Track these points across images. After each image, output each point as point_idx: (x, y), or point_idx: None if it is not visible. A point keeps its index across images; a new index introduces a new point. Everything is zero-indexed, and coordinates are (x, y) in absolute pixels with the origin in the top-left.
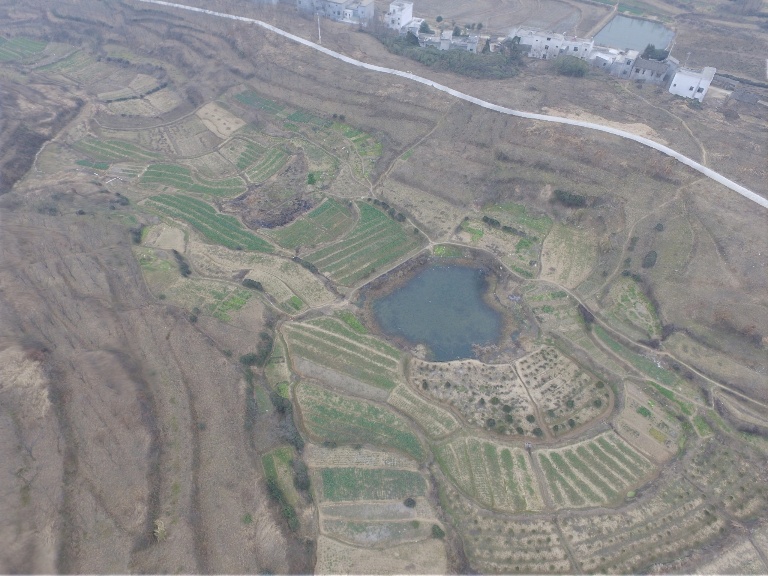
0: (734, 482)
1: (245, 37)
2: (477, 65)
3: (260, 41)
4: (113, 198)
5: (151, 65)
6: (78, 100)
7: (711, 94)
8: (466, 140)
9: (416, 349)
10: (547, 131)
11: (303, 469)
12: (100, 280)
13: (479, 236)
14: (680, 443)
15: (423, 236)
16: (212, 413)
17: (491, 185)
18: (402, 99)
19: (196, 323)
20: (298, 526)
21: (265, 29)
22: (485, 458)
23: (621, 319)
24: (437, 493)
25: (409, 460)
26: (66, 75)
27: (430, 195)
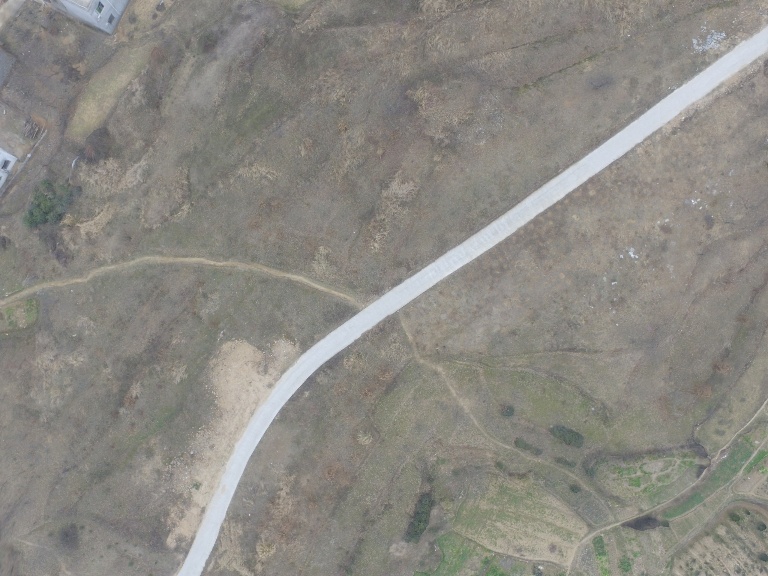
0: None
1: None
2: None
3: None
4: None
5: None
6: None
7: None
8: None
9: None
10: None
11: None
12: None
13: None
14: None
15: None
16: None
17: None
18: None
19: None
20: None
21: None
22: None
23: None
24: None
25: None
26: None
27: None
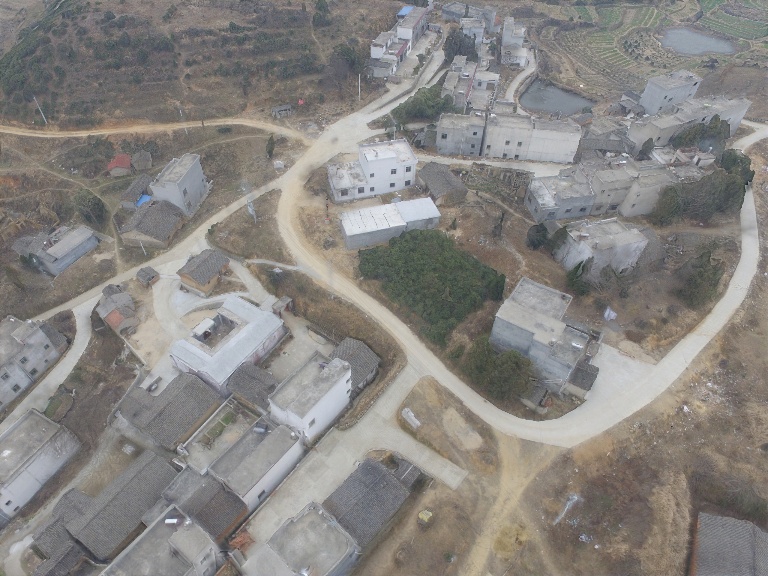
0: None
1: None
2: None
3: None
4: None
5: None
6: None
7: None
8: None
9: None
10: None
11: (584, 2)
12: None
13: (764, 47)
14: None
15: None
16: None
17: None
18: None
19: None
20: (563, 0)
21: None
22: None
23: None
24: (586, 22)
25: None
26: None
27: None
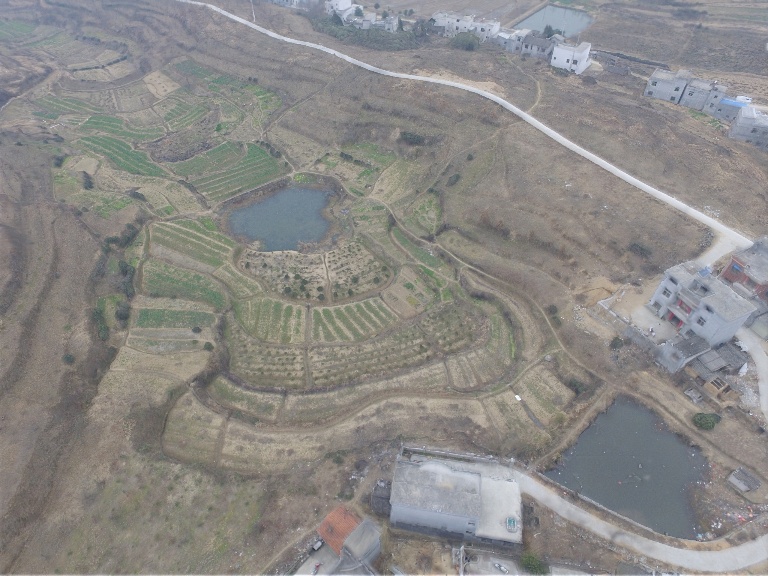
0: (454, 330)
1: (195, 17)
2: (381, 39)
3: (206, 21)
4: (51, 137)
5: (117, 42)
6: (48, 68)
7: (592, 68)
8: (344, 95)
9: (253, 244)
10: (407, 86)
11: (126, 307)
12: (16, 186)
13: (332, 167)
14: (428, 307)
15: (291, 168)
16: (68, 269)
17: (351, 128)
18: (306, 65)
19: (80, 217)
20: (107, 338)
21: (213, 11)
22: (272, 311)
23: (414, 222)
24: (220, 325)
25: (210, 307)
26: (46, 50)
27: (305, 137)
